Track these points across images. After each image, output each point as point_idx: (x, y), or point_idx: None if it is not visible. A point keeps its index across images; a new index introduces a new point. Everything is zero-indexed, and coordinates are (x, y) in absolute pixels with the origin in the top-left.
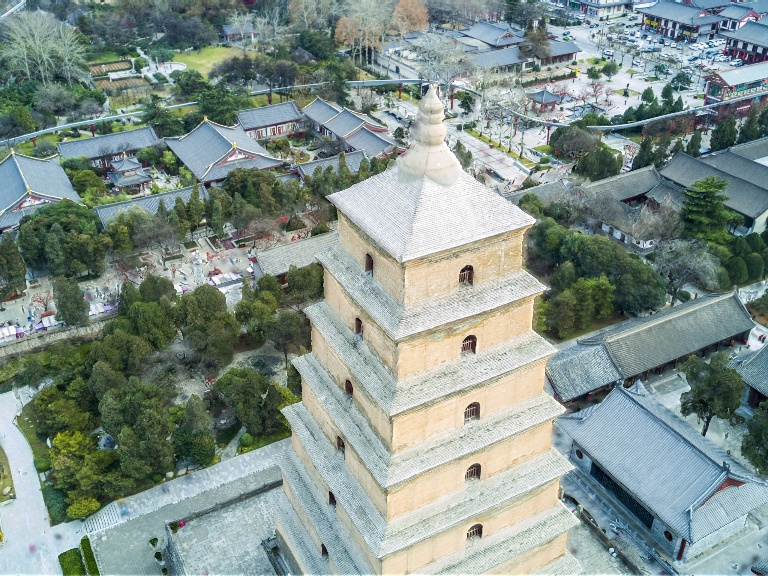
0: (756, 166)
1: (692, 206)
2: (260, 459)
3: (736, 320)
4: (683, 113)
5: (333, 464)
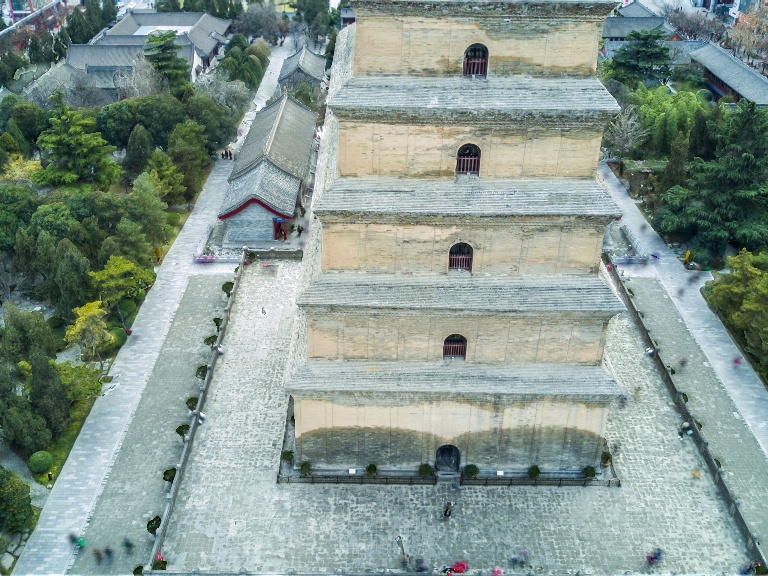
0: (142, 39)
1: (160, 62)
2: (89, 464)
3: (306, 114)
4: (13, 28)
5: (466, 191)
